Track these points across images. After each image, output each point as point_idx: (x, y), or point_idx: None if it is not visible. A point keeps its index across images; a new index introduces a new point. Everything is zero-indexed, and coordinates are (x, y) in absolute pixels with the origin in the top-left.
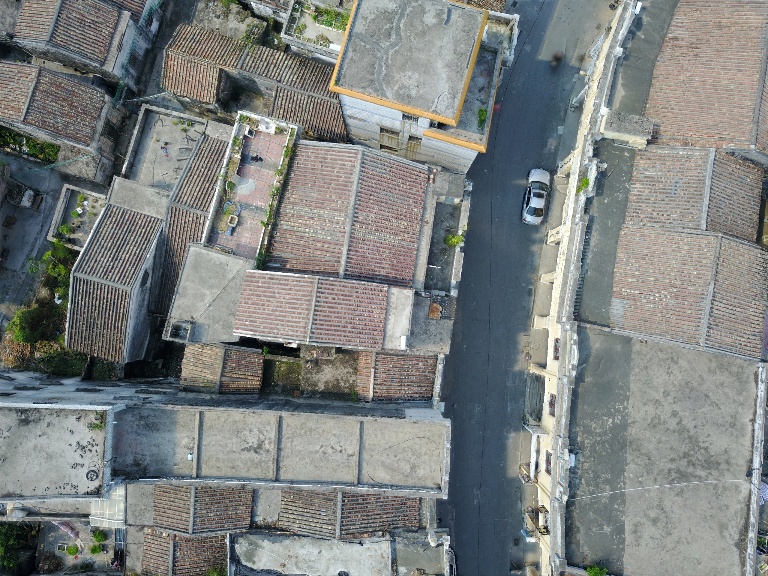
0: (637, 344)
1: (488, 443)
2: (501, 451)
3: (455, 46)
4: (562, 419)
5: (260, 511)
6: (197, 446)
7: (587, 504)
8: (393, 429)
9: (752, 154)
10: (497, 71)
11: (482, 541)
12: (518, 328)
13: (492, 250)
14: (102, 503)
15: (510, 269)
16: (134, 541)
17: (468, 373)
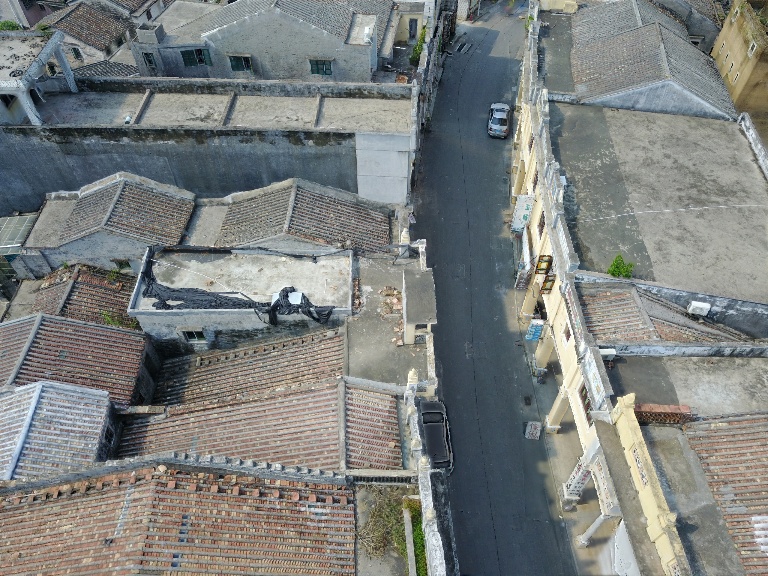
0: (609, 112)
1: (477, 298)
2: (493, 306)
3: None
4: (545, 159)
5: (193, 241)
6: (138, 113)
7: (592, 226)
8: (356, 105)
9: None
10: None
11: (481, 400)
12: (497, 206)
13: (463, 154)
14: (2, 235)
15: (482, 166)
16: (22, 303)
17: (448, 239)
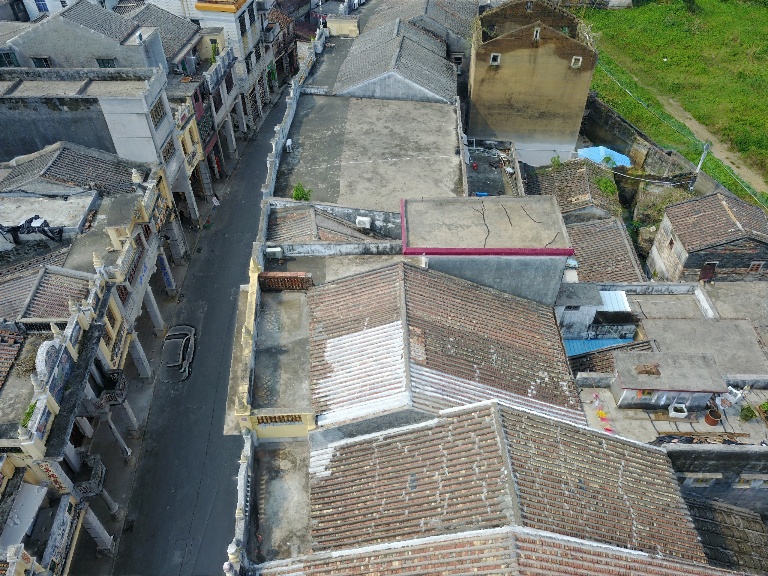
0: (354, 100)
1: None
2: None
3: None
4: None
5: None
6: None
7: (303, 173)
8: (116, 85)
9: (426, 22)
10: None
11: (233, 328)
12: None
13: None
14: None
15: None
16: None
17: (243, 216)
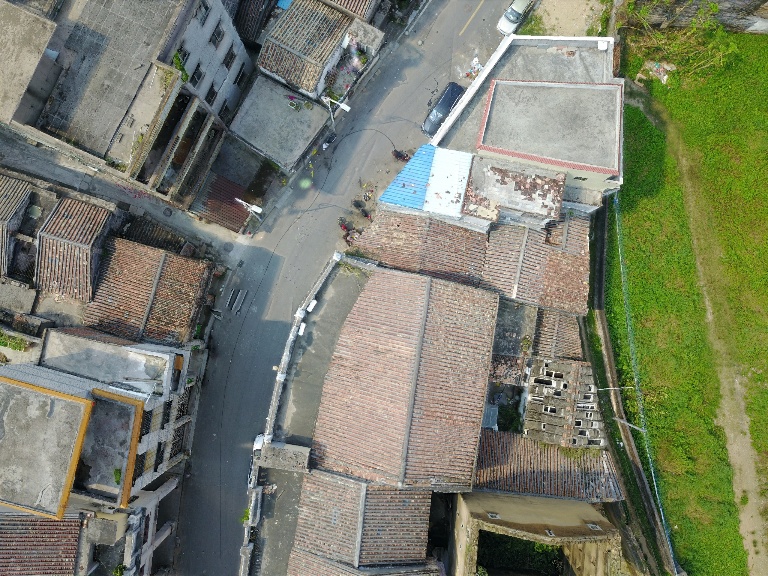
0: None
1: None
2: None
3: (58, 438)
4: None
5: None
6: None
7: None
8: None
9: None
10: (130, 431)
11: None
12: None
13: (222, 516)
14: None
15: (240, 535)
16: None
17: None
